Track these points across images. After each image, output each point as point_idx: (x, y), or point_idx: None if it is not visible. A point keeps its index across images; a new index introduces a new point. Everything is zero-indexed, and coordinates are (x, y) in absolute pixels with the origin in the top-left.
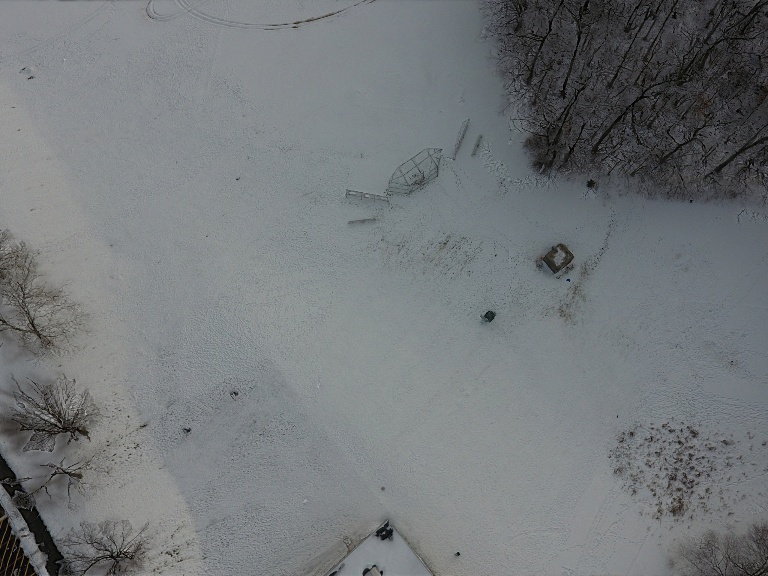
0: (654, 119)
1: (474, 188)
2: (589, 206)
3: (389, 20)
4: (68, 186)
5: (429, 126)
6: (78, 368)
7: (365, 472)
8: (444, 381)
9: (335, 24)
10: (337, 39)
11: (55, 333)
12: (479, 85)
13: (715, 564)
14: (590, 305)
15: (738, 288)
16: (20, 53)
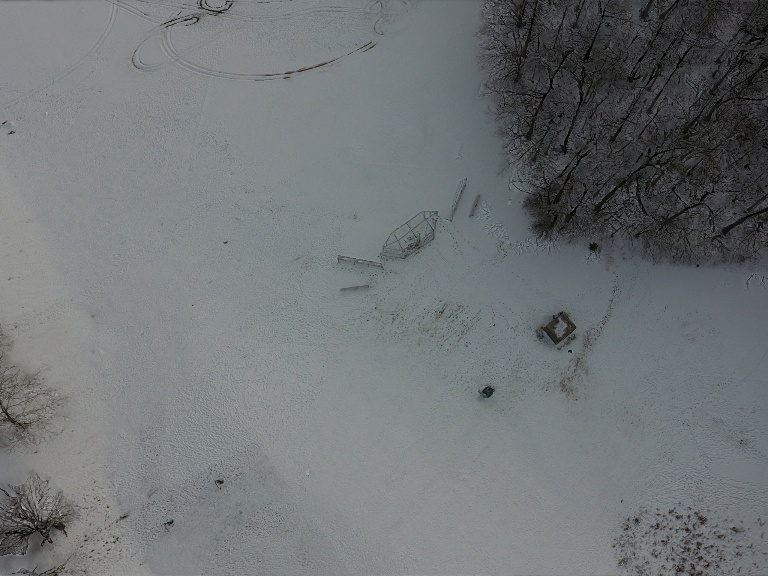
0: (659, 177)
1: (472, 252)
2: (592, 271)
3: (384, 70)
4: (48, 251)
5: (425, 185)
6: (55, 454)
7: (356, 569)
8: (440, 464)
9: (328, 74)
10: (330, 90)
11: (30, 420)
12: (477, 141)
13: None
14: (593, 379)
15: (747, 360)
16: (0, 106)
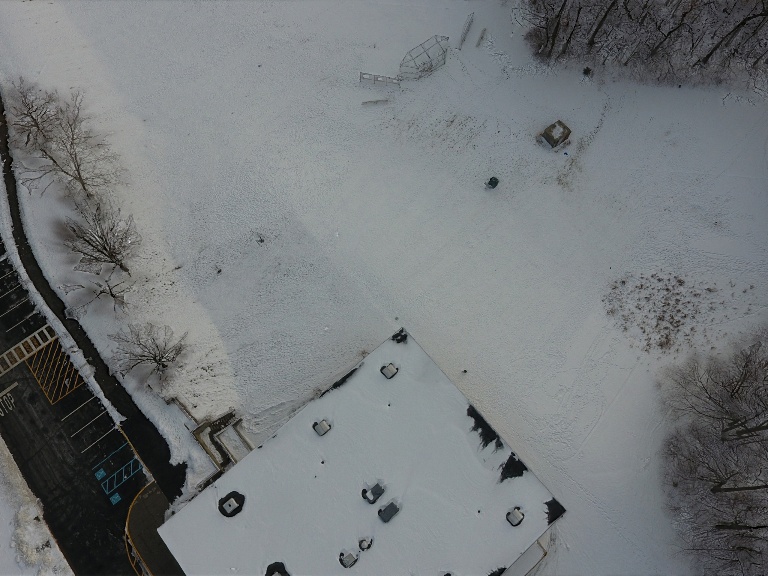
0: (646, 15)
1: (479, 74)
2: (585, 91)
3: None
4: (103, 70)
5: (437, 21)
6: None
7: (380, 305)
8: (452, 235)
9: None
10: None
11: (98, 183)
12: None
13: (697, 379)
14: (586, 175)
15: (722, 160)
16: None
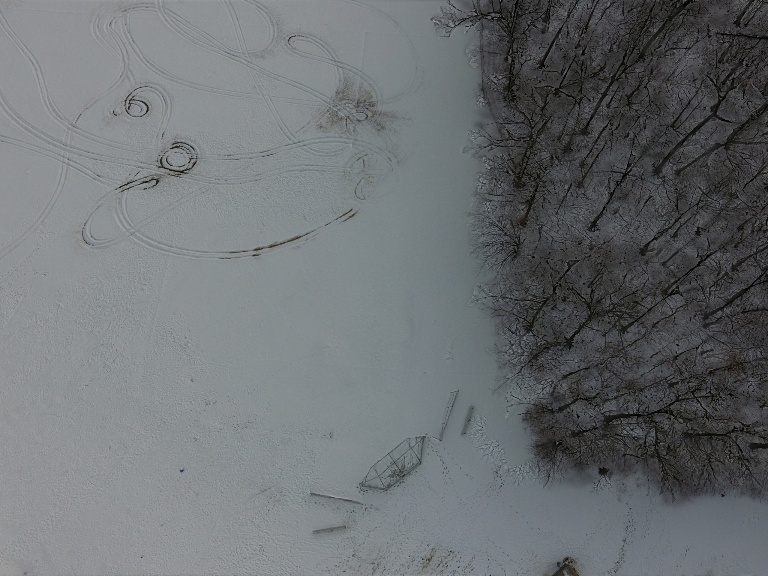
0: (677, 382)
1: (464, 480)
2: (601, 502)
3: (365, 245)
4: None
5: (411, 393)
6: None
7: None
8: None
9: (302, 251)
10: (304, 272)
11: None
12: (470, 338)
13: None
14: None
15: None
16: None
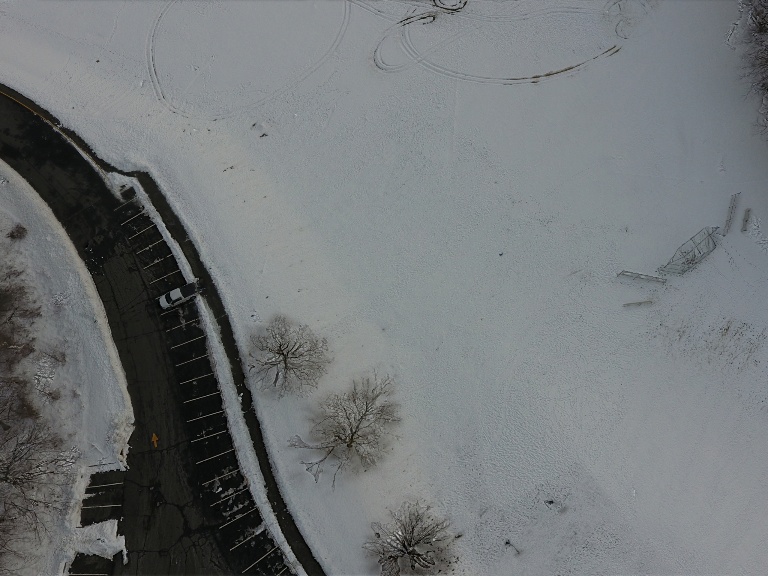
0: None
1: (749, 268)
2: None
3: (633, 76)
4: (327, 261)
5: (692, 197)
6: (383, 473)
7: None
8: (754, 485)
9: (576, 79)
10: (581, 97)
11: None
12: (741, 153)
13: None
14: None
15: None
16: (247, 107)
